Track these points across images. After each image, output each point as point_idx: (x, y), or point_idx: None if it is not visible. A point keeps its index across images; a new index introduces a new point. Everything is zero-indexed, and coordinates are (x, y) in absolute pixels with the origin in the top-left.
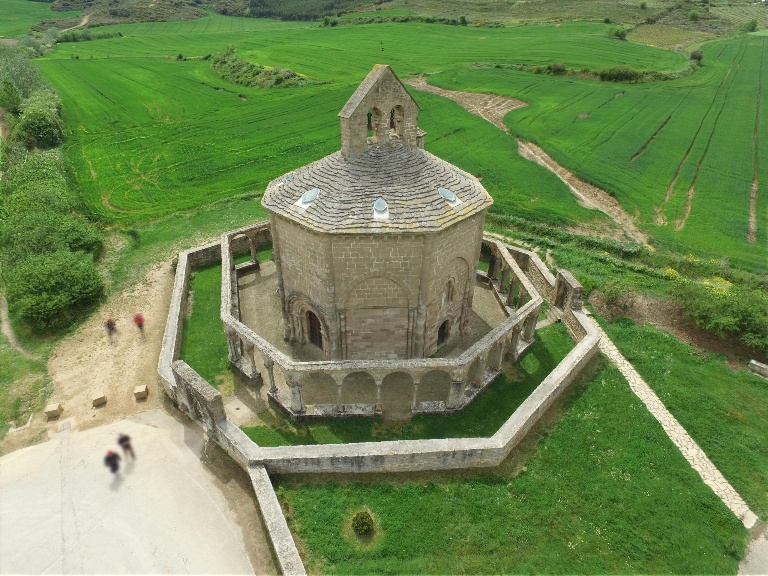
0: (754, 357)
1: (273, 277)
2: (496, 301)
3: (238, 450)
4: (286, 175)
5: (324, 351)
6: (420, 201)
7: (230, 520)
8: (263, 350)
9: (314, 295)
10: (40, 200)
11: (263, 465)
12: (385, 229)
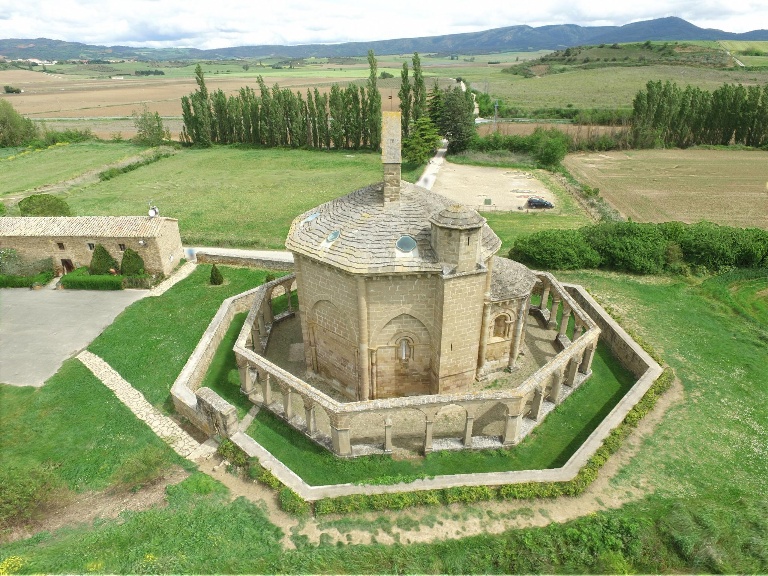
0: None
1: None
2: None
3: None
4: None
5: None
6: None
7: None
8: None
9: None
10: (693, 229)
11: None
12: None
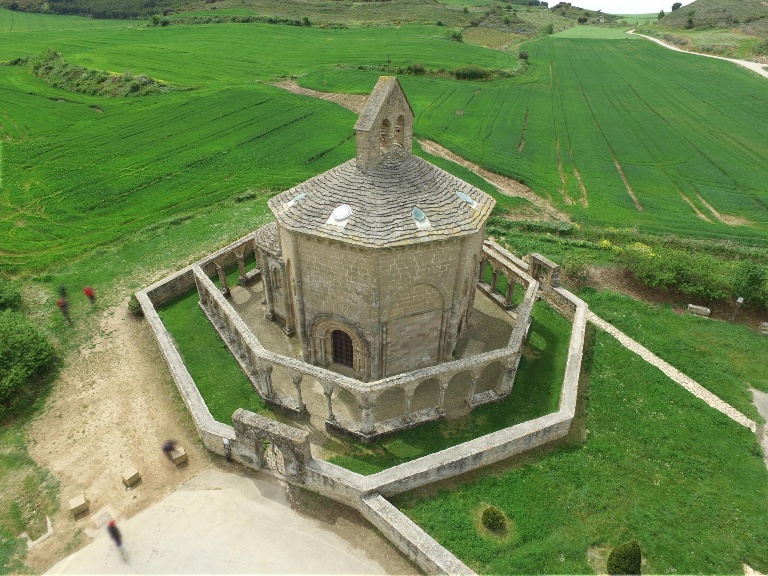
0: (688, 302)
1: (252, 303)
2: (478, 291)
3: (344, 485)
4: (288, 193)
5: (357, 368)
6: (451, 206)
7: (361, 558)
8: (327, 378)
9: (350, 313)
10: None
11: (377, 493)
12: (432, 237)
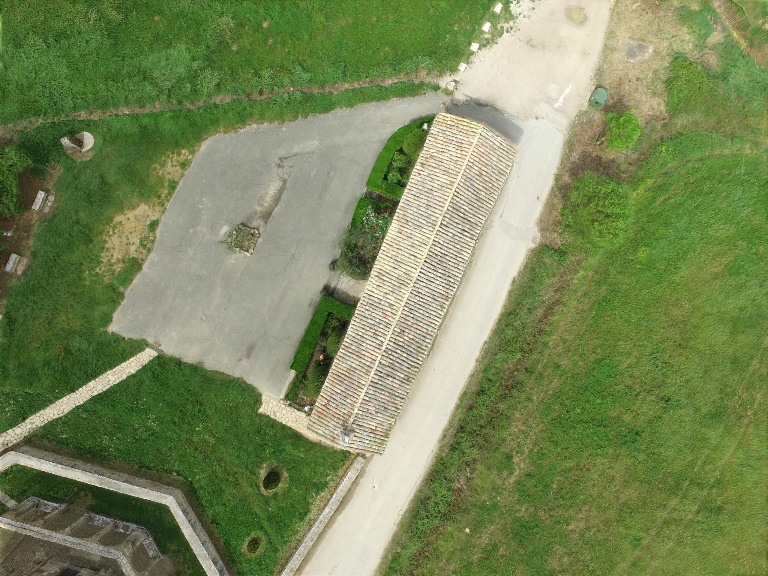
0: None
1: None
2: None
3: None
4: None
5: None
6: None
7: None
8: None
9: None
10: None
11: None
12: None
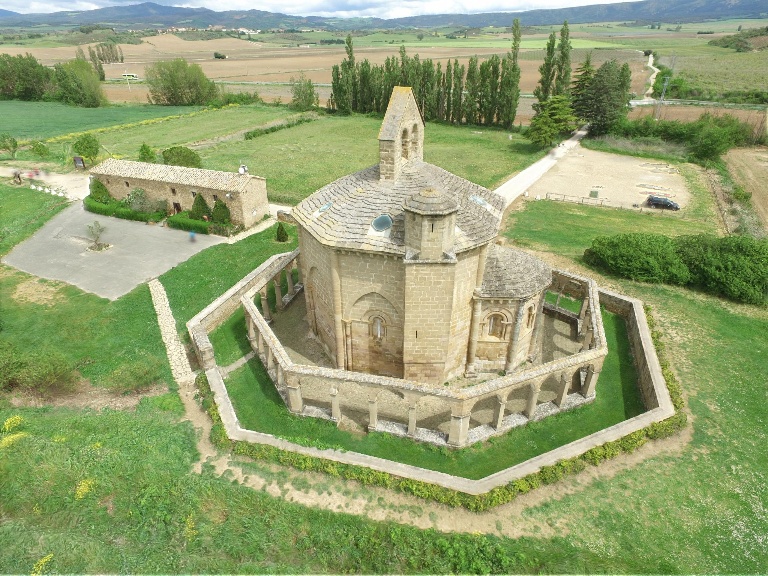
0: None
1: (545, 337)
2: None
3: None
4: None
5: None
6: None
7: None
8: None
9: None
10: None
11: None
12: None
